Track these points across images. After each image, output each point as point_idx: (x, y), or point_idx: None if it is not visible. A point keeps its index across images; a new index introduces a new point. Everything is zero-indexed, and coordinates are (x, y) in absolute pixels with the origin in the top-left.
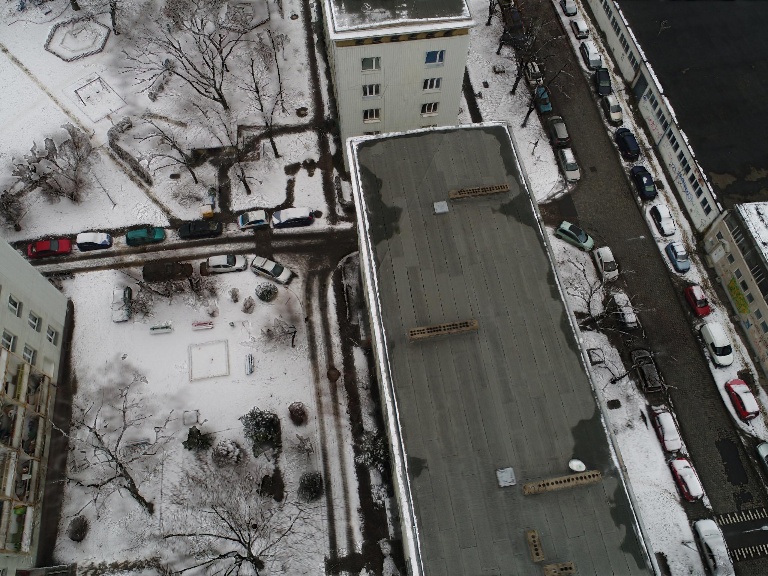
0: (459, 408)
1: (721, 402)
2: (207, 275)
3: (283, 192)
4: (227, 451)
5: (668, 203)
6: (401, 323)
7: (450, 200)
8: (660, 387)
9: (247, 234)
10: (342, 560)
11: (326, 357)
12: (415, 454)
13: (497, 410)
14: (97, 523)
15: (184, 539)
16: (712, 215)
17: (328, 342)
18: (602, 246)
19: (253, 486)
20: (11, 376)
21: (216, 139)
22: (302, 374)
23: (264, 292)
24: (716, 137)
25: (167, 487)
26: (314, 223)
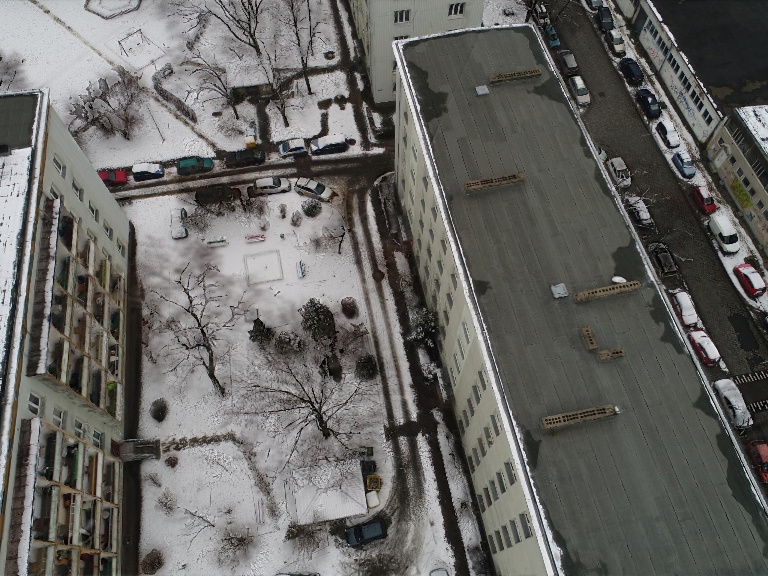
0: (514, 242)
1: (731, 284)
2: (255, 197)
3: (318, 124)
4: (289, 339)
5: (672, 120)
6: (456, 181)
7: (490, 84)
8: (675, 272)
9: (288, 161)
10: (400, 427)
11: (370, 261)
12: (479, 278)
13: (547, 242)
14: (175, 406)
15: (255, 416)
16: (713, 124)
17: (371, 249)
18: (615, 157)
19: (314, 370)
20: (95, 271)
21: (254, 78)
22: (350, 276)
23: (310, 207)
24: (713, 56)
25: (235, 374)
26: (349, 149)
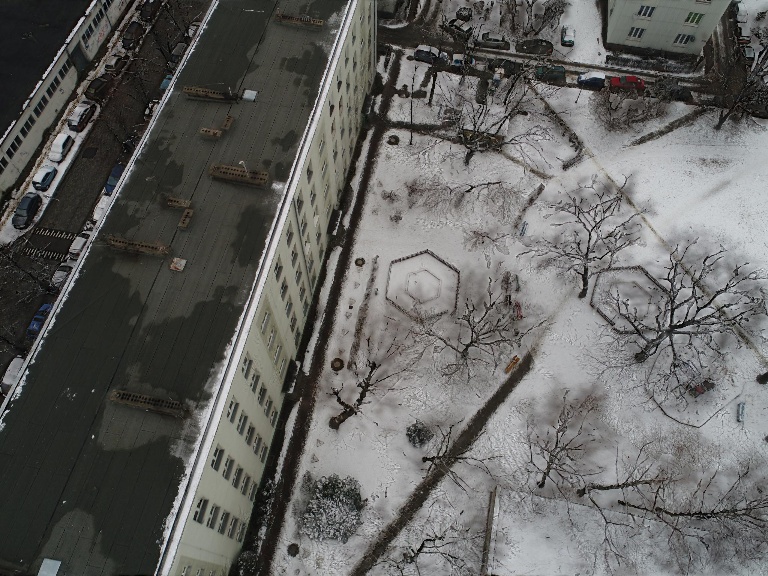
0: None
1: None
2: None
3: None
4: None
5: None
6: None
7: None
8: None
9: None
10: None
11: None
12: None
13: None
14: None
15: None
16: None
17: None
18: None
19: None
20: None
21: None
22: None
23: (466, 9)
24: None
25: None
26: None
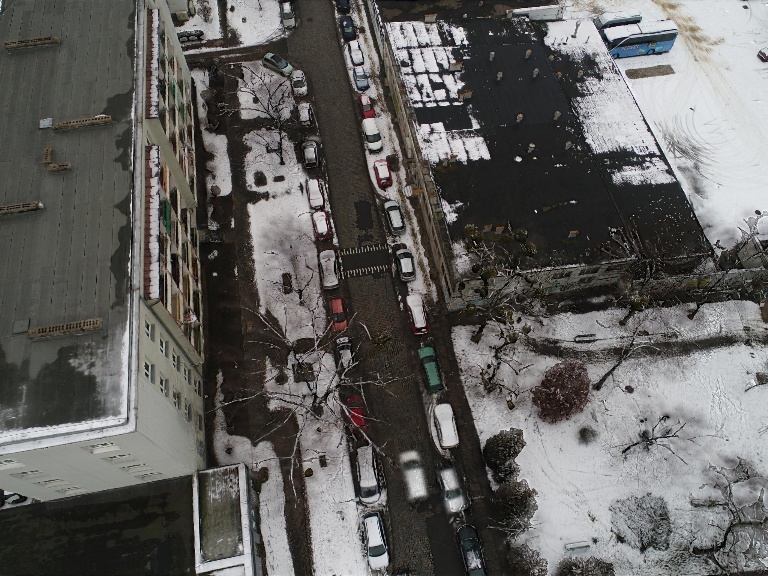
0: (29, 88)
1: (368, 177)
2: None
3: None
4: None
5: (365, 43)
6: None
7: None
8: (315, 164)
9: None
10: None
11: None
12: None
13: (56, 88)
14: None
15: None
16: None
17: None
18: None
19: None
20: None
21: None
22: None
23: None
24: None
25: None
26: None
